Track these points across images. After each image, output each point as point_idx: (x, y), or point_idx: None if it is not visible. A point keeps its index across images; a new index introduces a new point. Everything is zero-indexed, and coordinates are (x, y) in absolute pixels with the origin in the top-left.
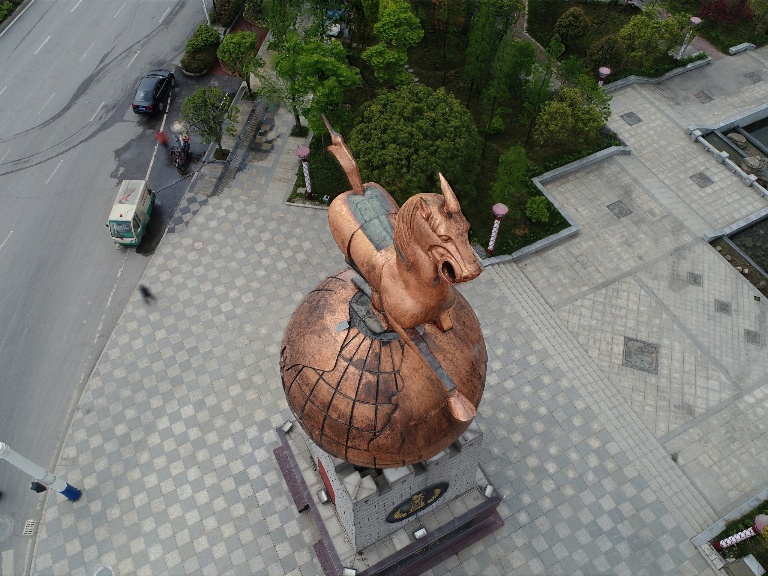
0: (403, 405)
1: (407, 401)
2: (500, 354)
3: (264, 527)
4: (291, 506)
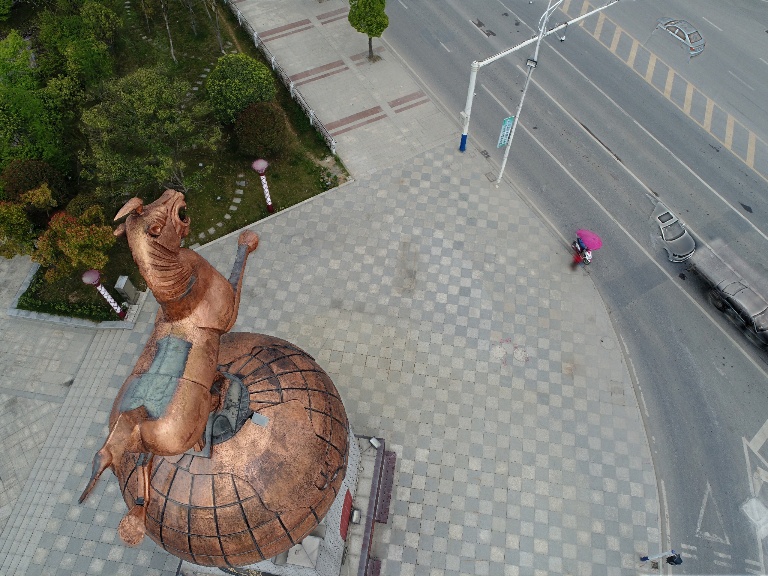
0: (268, 343)
1: (263, 342)
2: (80, 575)
3: (418, 573)
4: (384, 574)
